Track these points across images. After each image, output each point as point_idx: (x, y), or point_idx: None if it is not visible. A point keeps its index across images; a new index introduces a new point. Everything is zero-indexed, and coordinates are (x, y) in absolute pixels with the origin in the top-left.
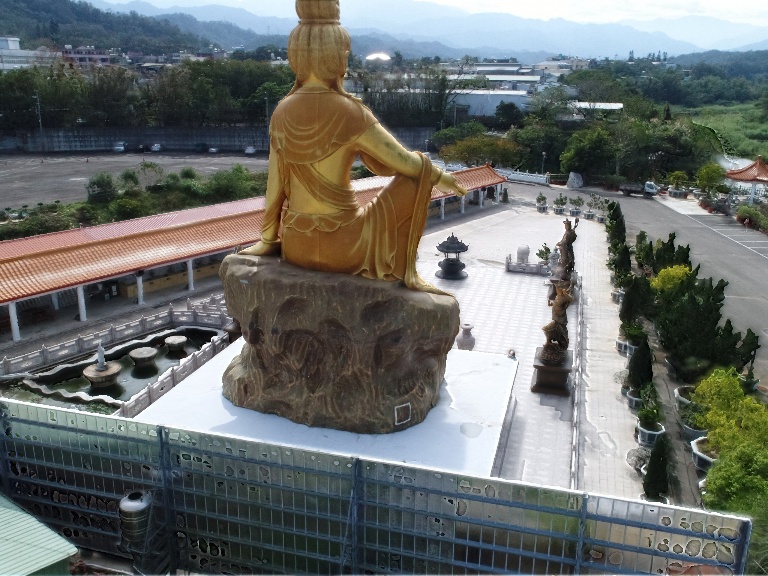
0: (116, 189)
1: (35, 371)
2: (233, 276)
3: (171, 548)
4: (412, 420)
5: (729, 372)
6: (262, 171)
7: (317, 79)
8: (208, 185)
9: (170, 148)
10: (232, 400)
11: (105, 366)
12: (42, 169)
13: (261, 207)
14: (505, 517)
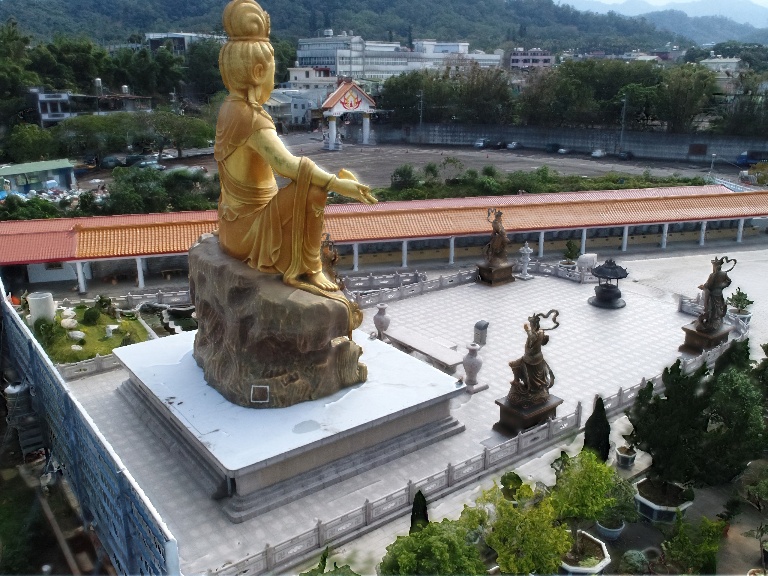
0: (415, 179)
1: (180, 306)
2: None
3: (43, 431)
4: (271, 403)
5: (584, 456)
6: (572, 174)
7: (233, 89)
8: (507, 183)
9: (527, 146)
10: None
11: None
12: (399, 158)
13: None
14: None
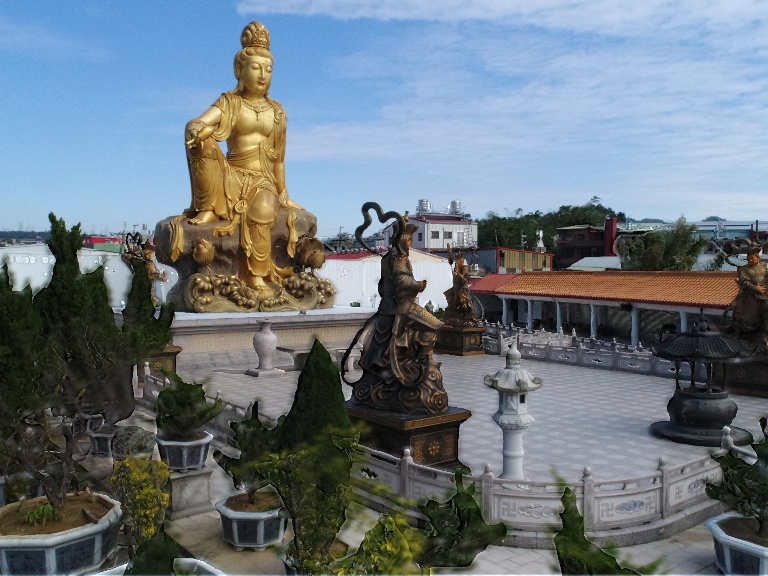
0: None
1: None
2: None
3: None
4: None
5: None
6: None
7: None
8: None
9: None
10: None
11: None
12: None
13: None
14: None
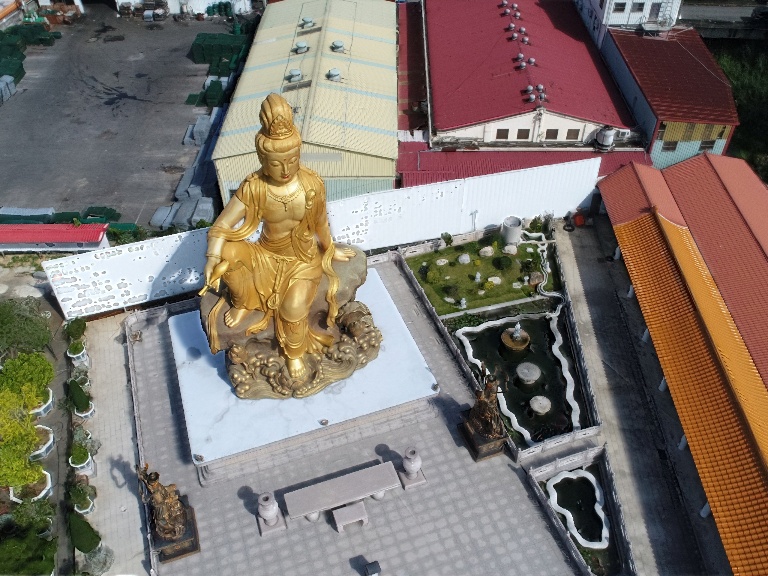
0: None
1: None
2: None
3: None
4: None
5: (8, 447)
6: None
7: None
8: None
9: None
10: None
11: None
12: None
13: None
14: None
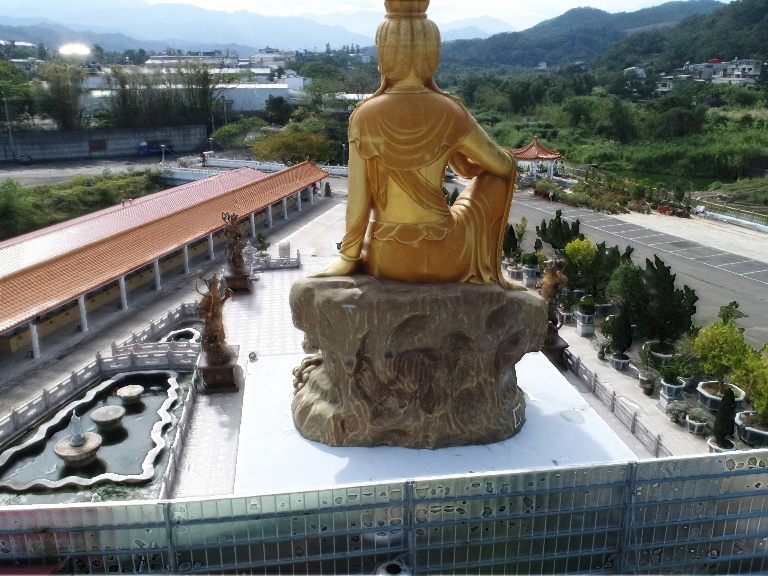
0: None
1: None
2: (330, 302)
3: None
4: (521, 420)
5: (730, 323)
6: (36, 184)
7: (416, 78)
8: None
9: None
10: (325, 441)
11: (83, 439)
12: None
13: (113, 225)
14: (763, 483)
